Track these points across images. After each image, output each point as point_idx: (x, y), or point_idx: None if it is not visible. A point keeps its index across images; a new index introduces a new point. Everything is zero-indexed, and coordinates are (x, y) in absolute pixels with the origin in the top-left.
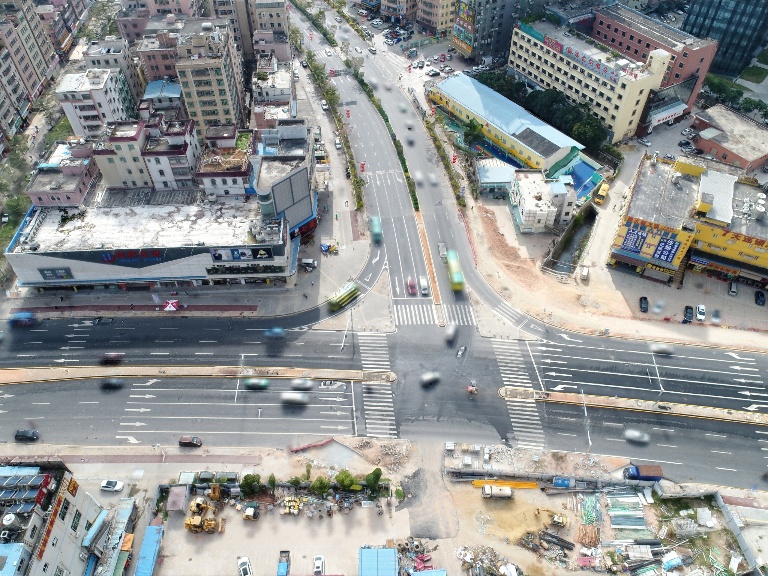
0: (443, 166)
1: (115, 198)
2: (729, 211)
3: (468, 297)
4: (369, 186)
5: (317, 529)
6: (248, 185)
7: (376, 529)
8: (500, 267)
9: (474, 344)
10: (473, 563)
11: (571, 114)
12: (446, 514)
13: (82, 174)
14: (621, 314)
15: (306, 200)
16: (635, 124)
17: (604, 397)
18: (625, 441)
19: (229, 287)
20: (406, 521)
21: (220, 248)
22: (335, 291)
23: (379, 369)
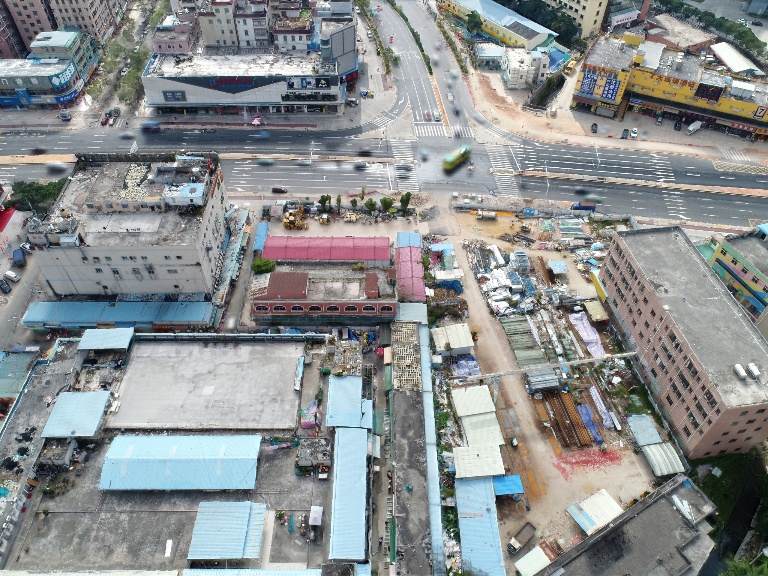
0: (451, 49)
1: (211, 52)
2: (656, 63)
3: (468, 122)
4: (394, 60)
5: (368, 229)
6: (310, 42)
7: (407, 230)
8: (492, 107)
9: (472, 147)
10: (470, 245)
11: (550, 15)
12: (452, 225)
13: (189, 31)
14: (578, 134)
15: (352, 54)
16: (599, 24)
17: (561, 173)
18: (573, 195)
19: (296, 114)
20: (426, 227)
21: (293, 77)
22: (372, 117)
23: (406, 158)
